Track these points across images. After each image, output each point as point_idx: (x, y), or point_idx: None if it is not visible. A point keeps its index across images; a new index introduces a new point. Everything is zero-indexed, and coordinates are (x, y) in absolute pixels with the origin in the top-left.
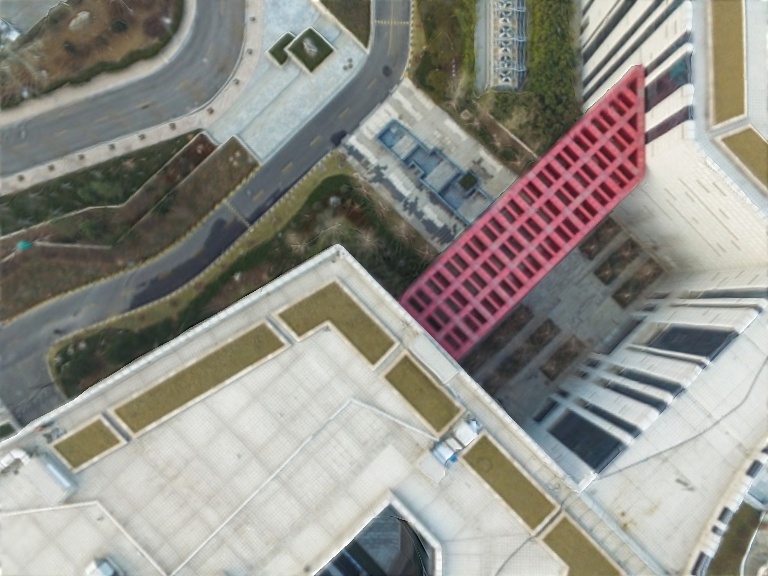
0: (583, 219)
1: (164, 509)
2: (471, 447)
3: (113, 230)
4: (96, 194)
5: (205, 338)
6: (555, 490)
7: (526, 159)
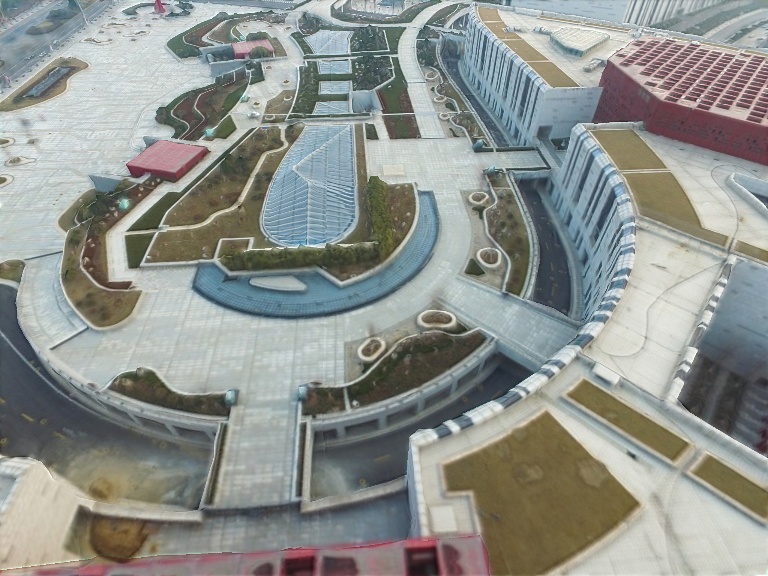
0: None
1: None
2: None
3: None
4: None
5: None
6: None
7: None
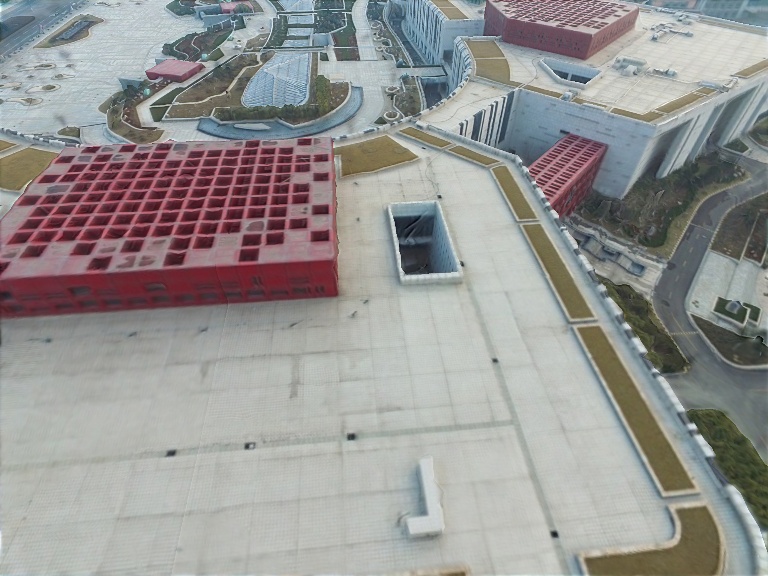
0: None
1: None
2: None
3: (767, 216)
4: None
5: None
6: None
7: None
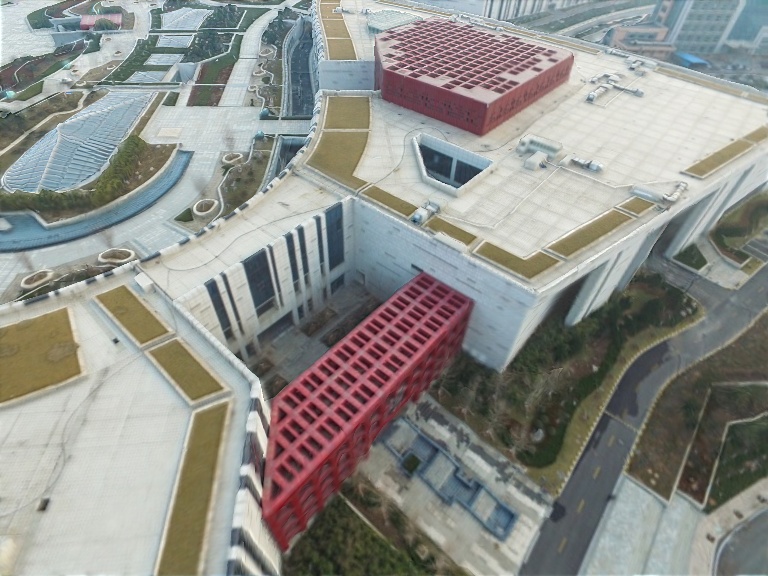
0: (331, 362)
1: (578, 187)
2: None
3: (721, 397)
4: (759, 426)
5: (600, 250)
6: None
7: (353, 489)
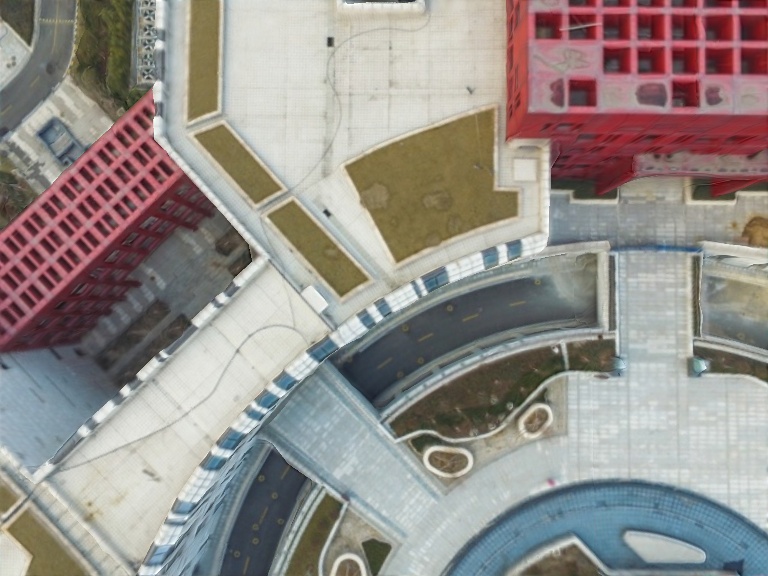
0: (123, 214)
1: None
2: None
3: None
4: None
5: None
6: (25, 480)
7: None
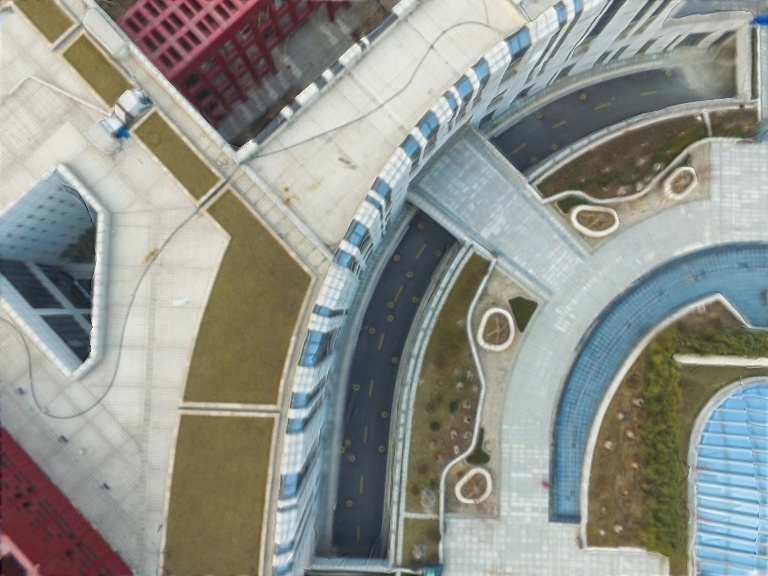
0: None
1: None
2: (142, 122)
3: None
4: None
5: None
6: (223, 166)
7: None
